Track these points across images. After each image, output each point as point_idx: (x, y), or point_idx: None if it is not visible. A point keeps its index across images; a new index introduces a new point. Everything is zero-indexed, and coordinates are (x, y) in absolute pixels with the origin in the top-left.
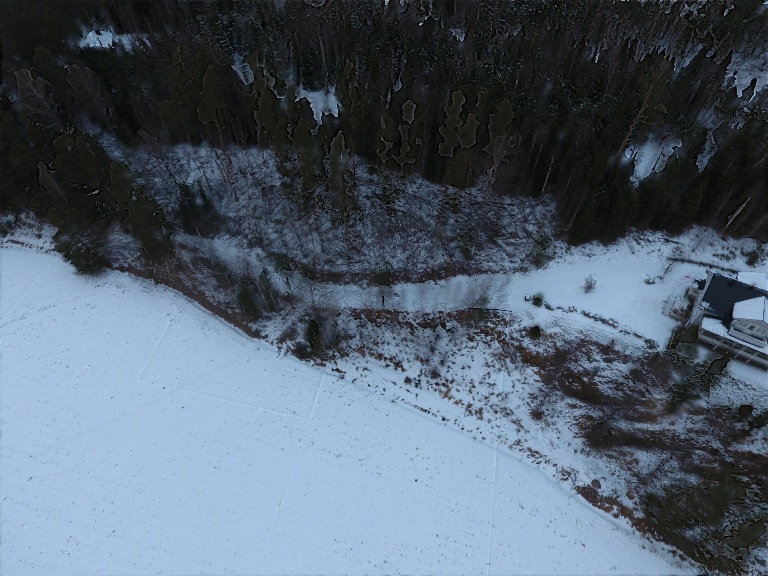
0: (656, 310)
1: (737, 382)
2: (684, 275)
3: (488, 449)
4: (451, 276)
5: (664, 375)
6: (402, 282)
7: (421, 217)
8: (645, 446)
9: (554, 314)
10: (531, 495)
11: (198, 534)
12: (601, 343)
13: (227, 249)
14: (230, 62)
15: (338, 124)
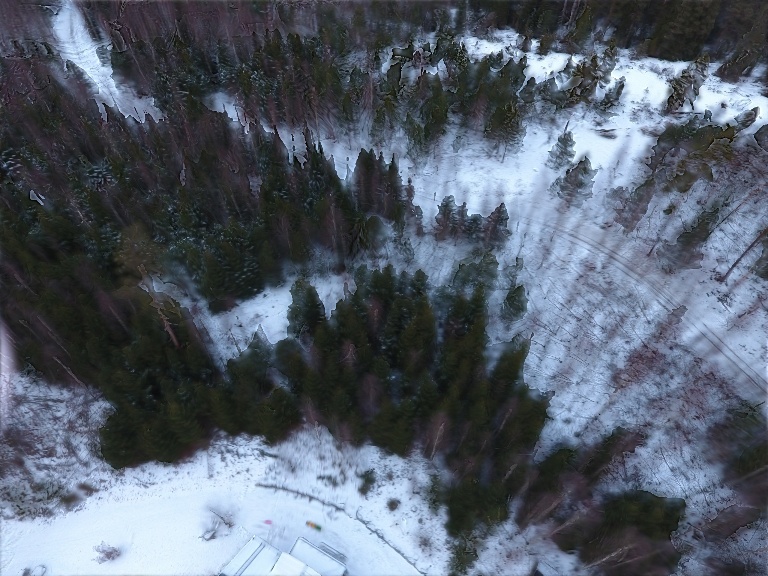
0: None
1: None
2: (265, 518)
3: None
4: None
5: None
6: None
7: None
8: None
9: None
10: None
11: None
12: None
13: None
14: None
15: None
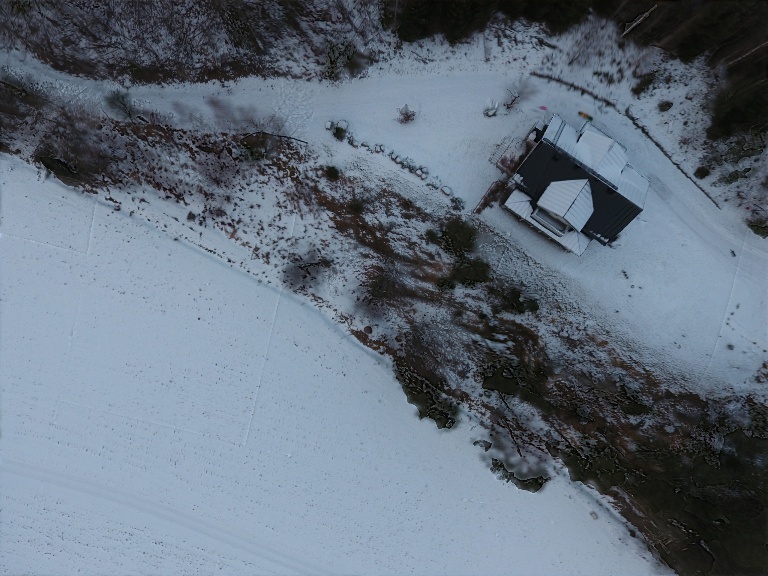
0: (483, 156)
1: (528, 259)
2: (540, 104)
3: (271, 293)
4: (241, 76)
5: None
6: (177, 81)
7: None
8: (426, 299)
9: (356, 153)
10: (306, 335)
11: (2, 356)
12: (403, 196)
13: None
14: None
15: None
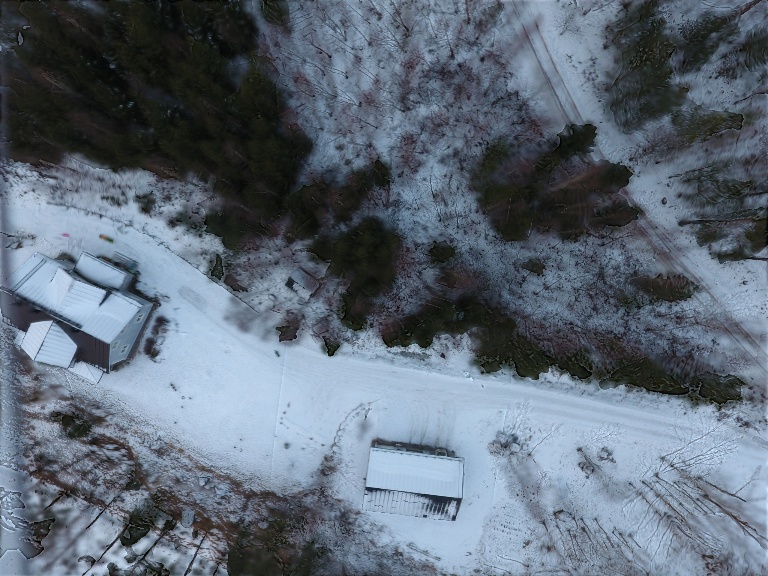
0: None
1: None
2: (62, 232)
3: None
4: None
5: (29, 365)
6: None
7: None
8: None
9: None
10: None
11: None
12: None
13: None
14: None
15: None
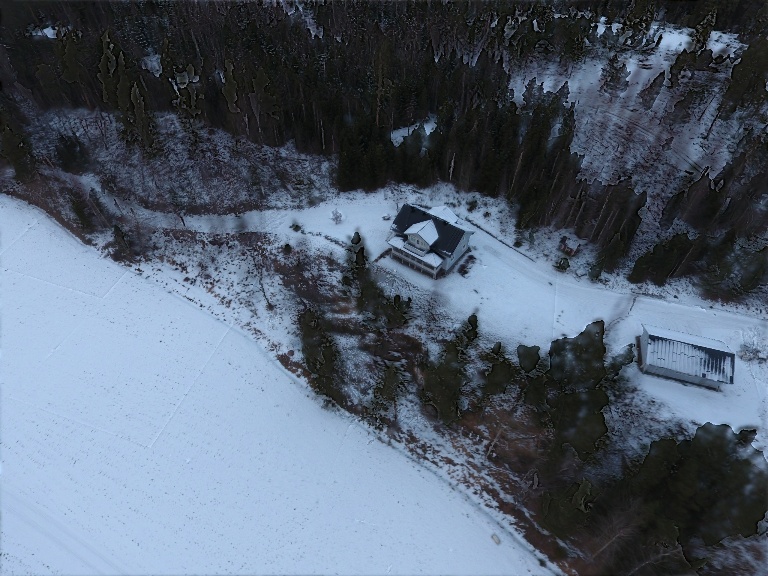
0: (382, 238)
1: (409, 285)
2: None
3: (224, 326)
4: (248, 211)
5: (365, 281)
6: (211, 213)
7: (236, 166)
8: (340, 332)
9: (305, 237)
10: (240, 357)
11: None
12: (330, 257)
13: (88, 183)
14: (145, 53)
15: (187, 94)
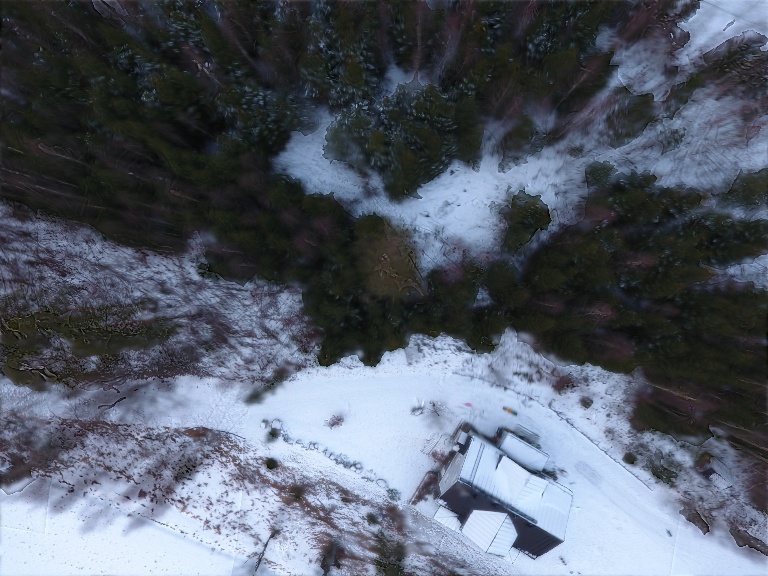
0: (415, 448)
1: (467, 546)
2: (465, 401)
3: (225, 560)
4: (178, 375)
5: (401, 522)
6: None
7: (116, 301)
8: None
9: (292, 449)
10: None
11: None
12: (341, 485)
13: None
14: None
15: None
